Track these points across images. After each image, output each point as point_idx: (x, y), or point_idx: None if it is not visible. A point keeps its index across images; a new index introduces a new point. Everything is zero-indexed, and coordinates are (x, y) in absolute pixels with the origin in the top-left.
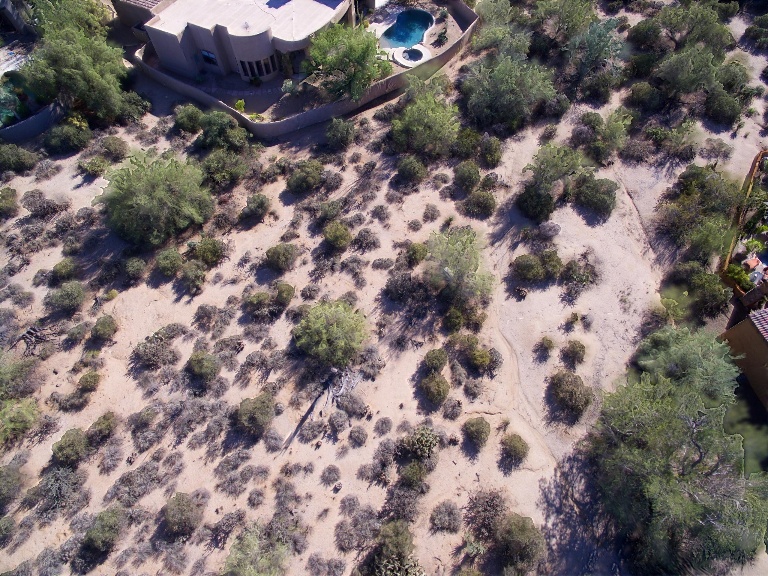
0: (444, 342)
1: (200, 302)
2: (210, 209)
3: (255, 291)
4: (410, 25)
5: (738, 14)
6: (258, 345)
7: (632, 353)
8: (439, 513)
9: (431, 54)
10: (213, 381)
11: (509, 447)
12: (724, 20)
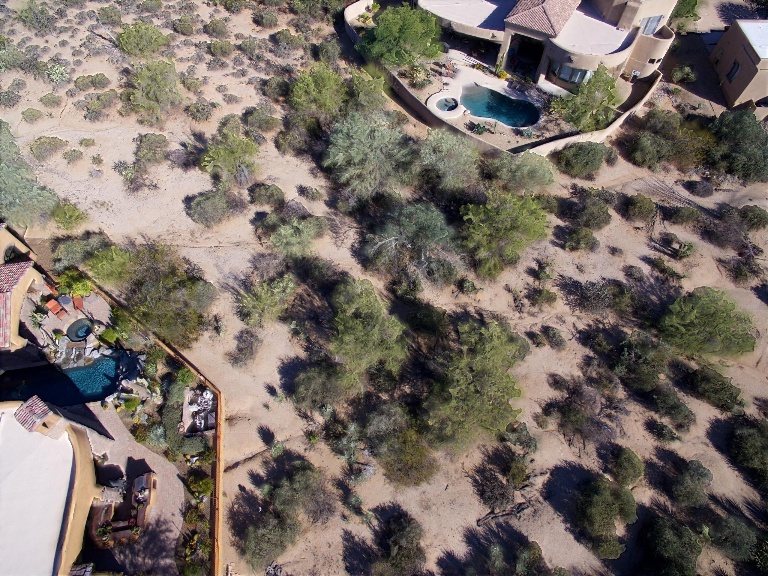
0: (117, 92)
1: (202, 6)
2: (270, 1)
3: (200, 24)
4: (521, 117)
5: (612, 573)
6: (160, 24)
7: (59, 195)
8: (20, 80)
9: (451, 118)
10: (141, 7)
11: (32, 108)
12: (577, 521)
